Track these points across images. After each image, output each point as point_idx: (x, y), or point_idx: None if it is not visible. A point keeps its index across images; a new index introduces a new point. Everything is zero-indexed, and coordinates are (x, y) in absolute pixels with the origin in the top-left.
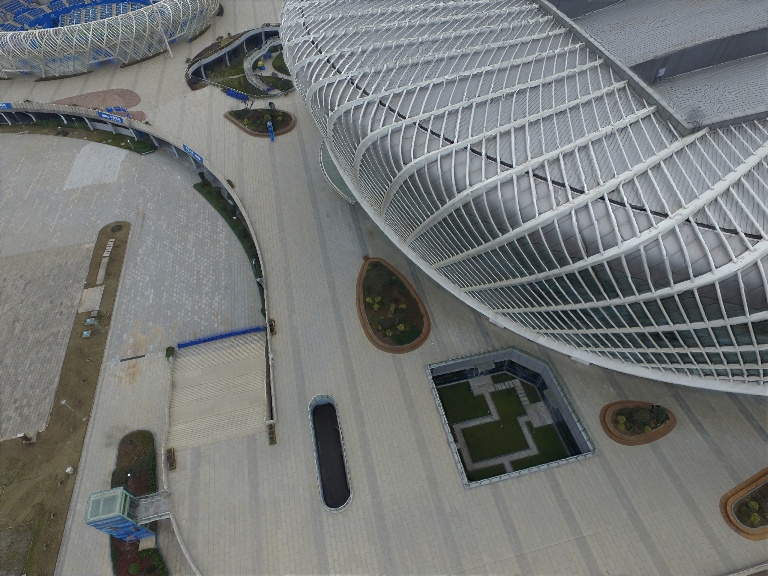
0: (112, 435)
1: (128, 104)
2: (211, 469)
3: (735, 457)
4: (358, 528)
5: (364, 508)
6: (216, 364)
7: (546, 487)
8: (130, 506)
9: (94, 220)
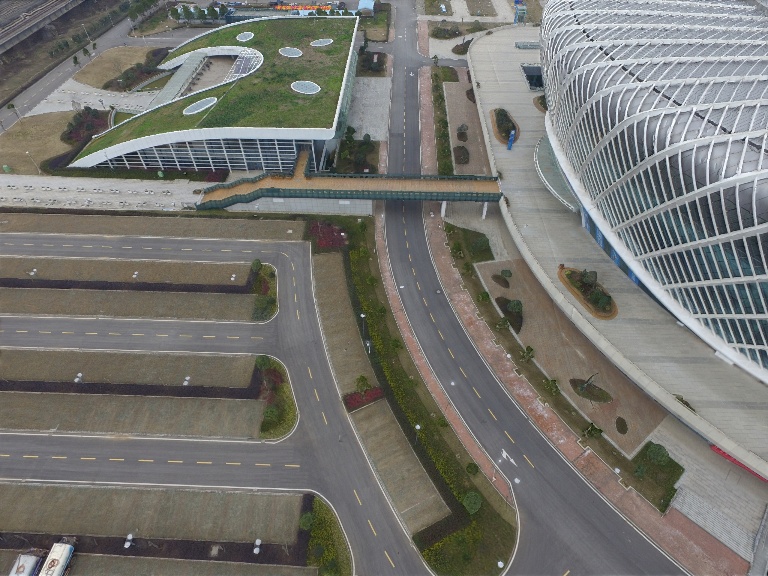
0: None
1: None
2: (533, 31)
3: (525, 120)
4: (509, 49)
5: None
6: None
7: (518, 79)
8: (522, 18)
9: None
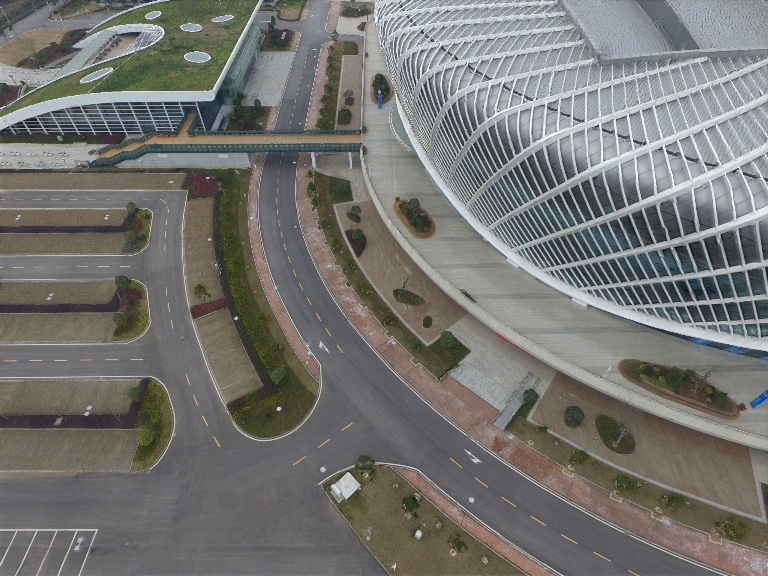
0: None
1: None
2: None
3: None
4: None
5: None
6: None
7: None
8: None
9: None
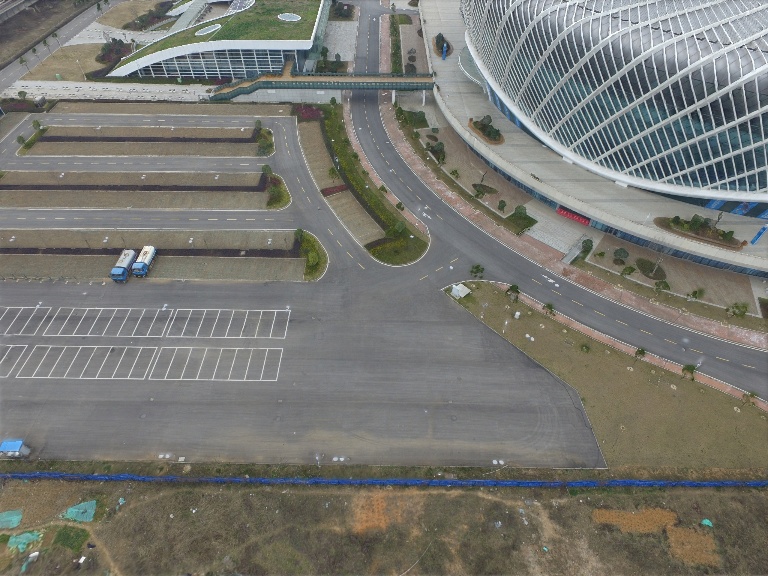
0: None
1: None
2: None
3: None
4: None
5: (457, 0)
6: None
7: (456, 18)
8: None
9: None
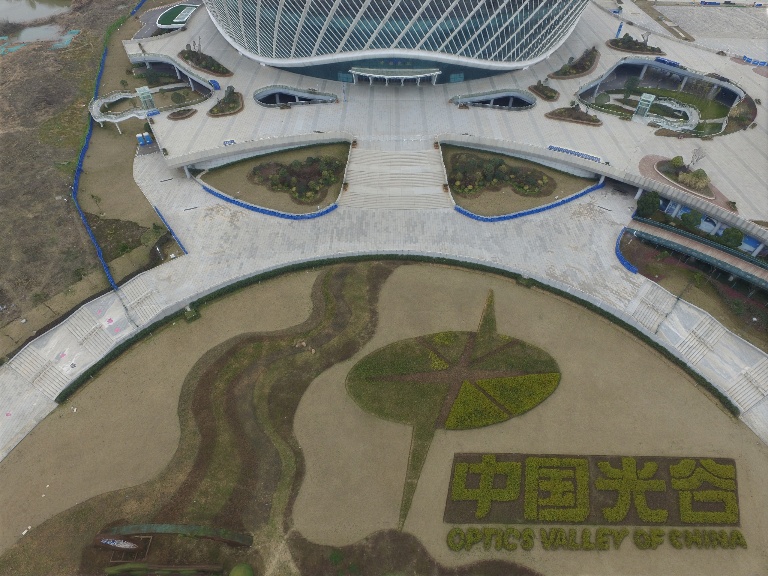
0: (627, 4)
1: (762, 70)
2: None
3: None
4: None
5: None
6: (601, 2)
7: None
8: None
9: (705, 43)
